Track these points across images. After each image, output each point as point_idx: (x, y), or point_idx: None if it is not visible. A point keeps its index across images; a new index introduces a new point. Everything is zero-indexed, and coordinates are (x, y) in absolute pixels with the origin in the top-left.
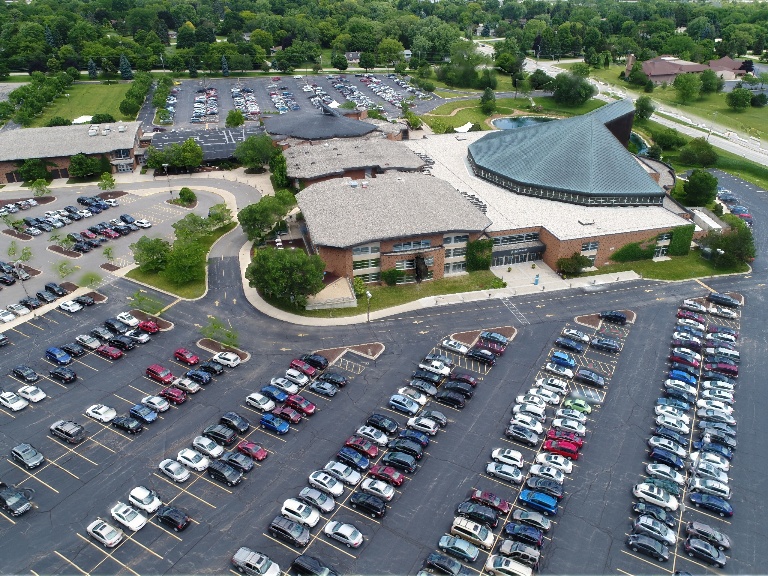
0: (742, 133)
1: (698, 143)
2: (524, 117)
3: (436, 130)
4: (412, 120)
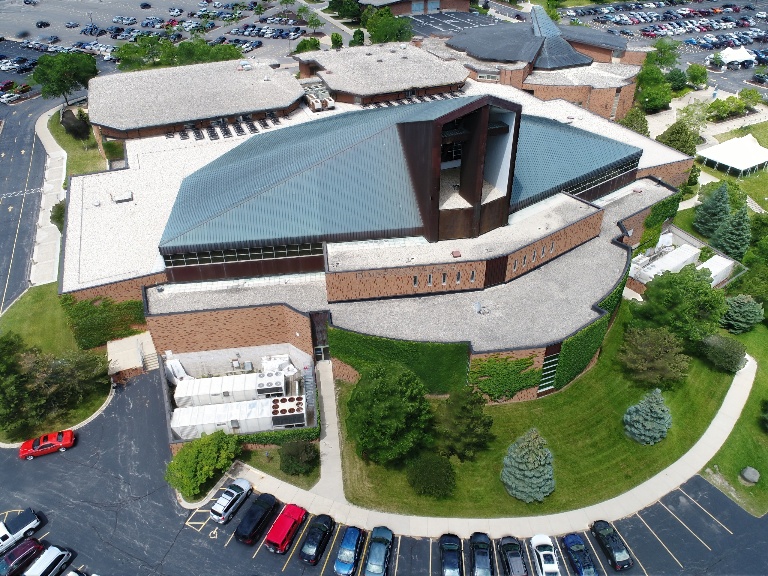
0: None
1: None
2: None
3: None
4: (716, 100)
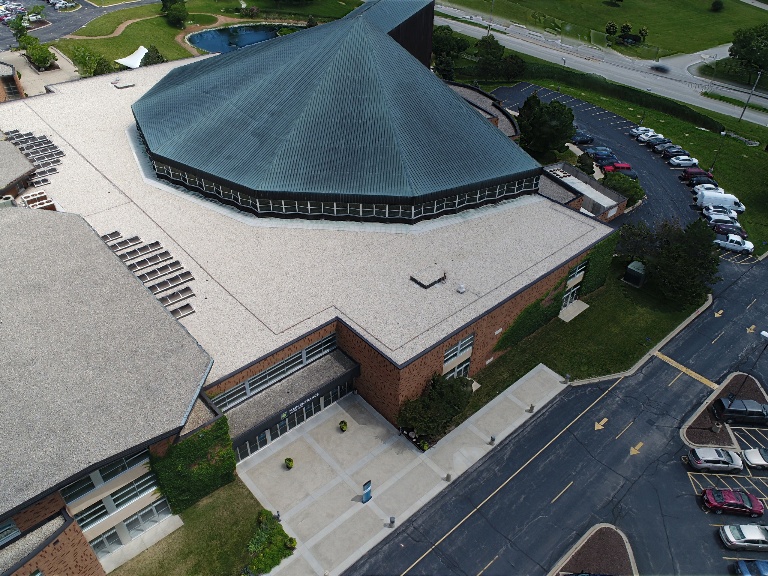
0: (534, 24)
1: (487, 45)
2: (234, 26)
3: (81, 68)
4: (33, 52)
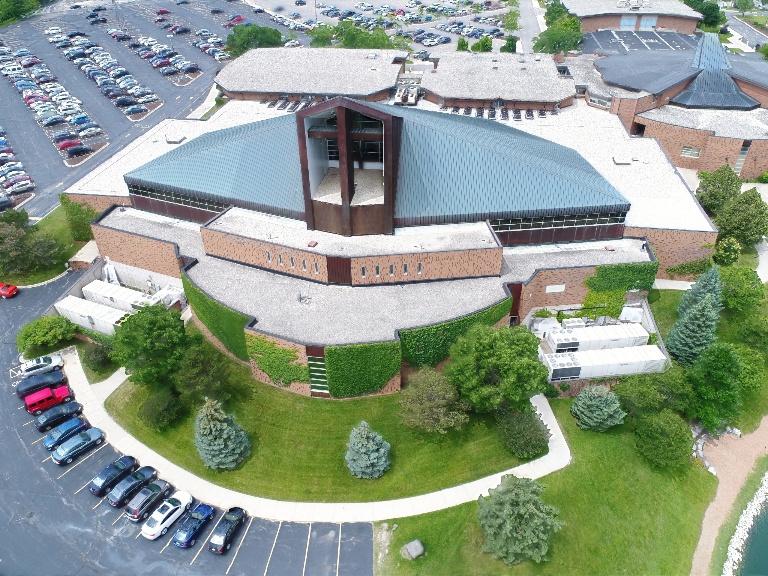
0: None
1: None
2: None
3: None
4: None
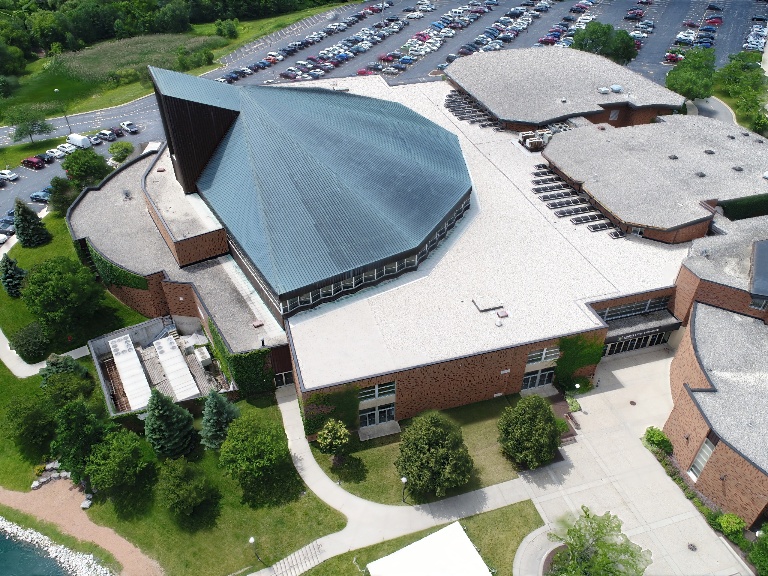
0: None
1: None
2: None
3: None
4: None
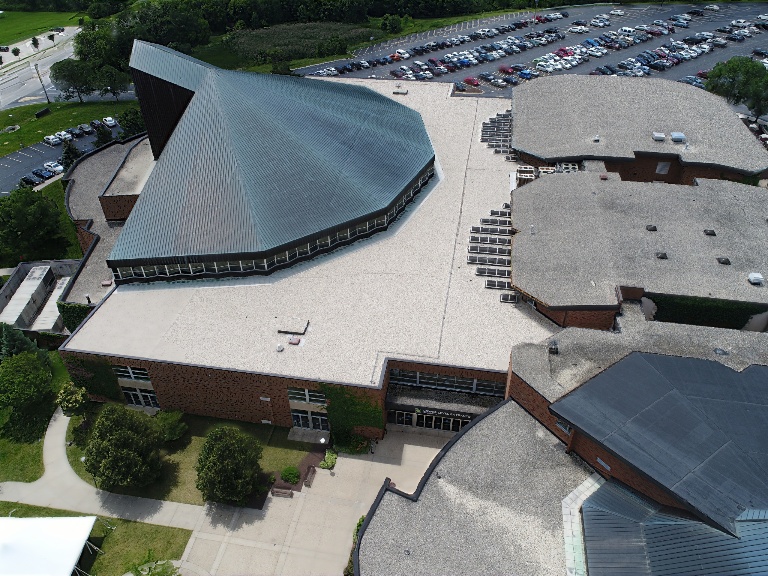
0: None
1: None
2: None
3: None
4: None
